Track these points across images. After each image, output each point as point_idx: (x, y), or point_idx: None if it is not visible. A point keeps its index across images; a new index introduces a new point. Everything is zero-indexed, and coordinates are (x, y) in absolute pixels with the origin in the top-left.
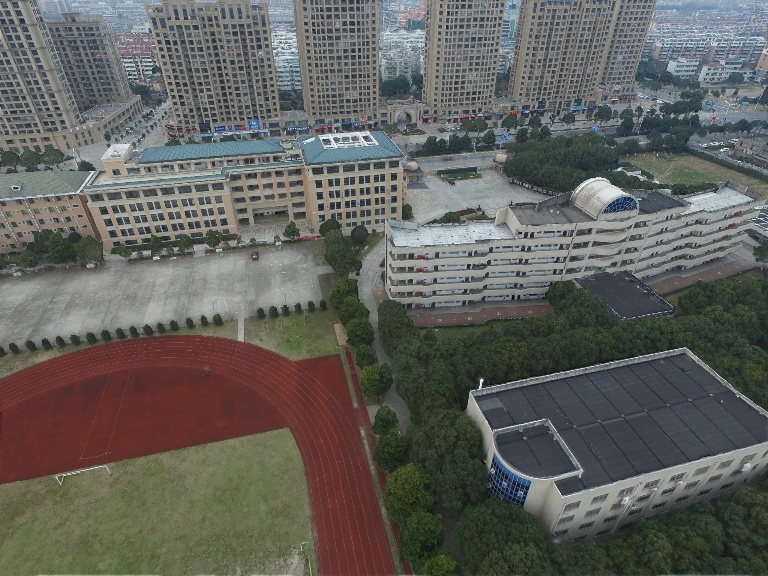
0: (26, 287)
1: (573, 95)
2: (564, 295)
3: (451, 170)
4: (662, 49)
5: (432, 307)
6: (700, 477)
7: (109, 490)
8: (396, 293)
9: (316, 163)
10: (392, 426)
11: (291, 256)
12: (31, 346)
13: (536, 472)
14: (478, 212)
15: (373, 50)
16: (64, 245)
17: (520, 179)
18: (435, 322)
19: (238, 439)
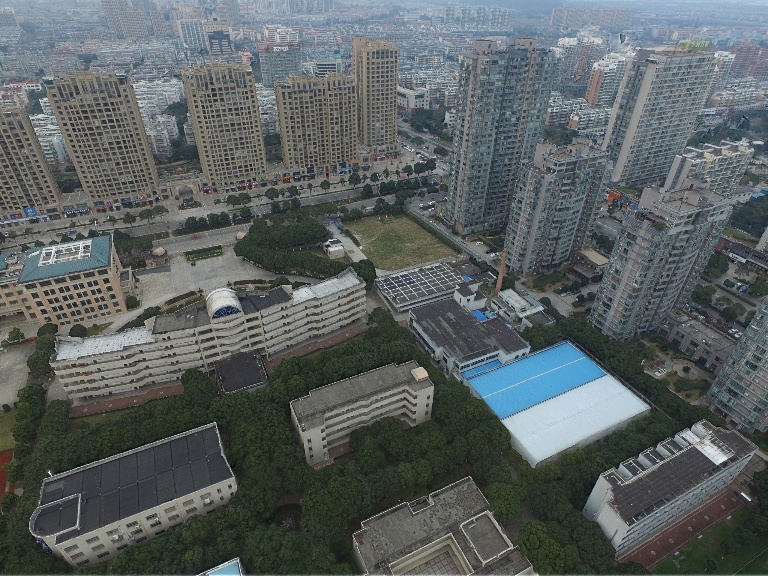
0: None
1: (338, 160)
2: (188, 380)
3: (197, 251)
4: (449, 96)
5: (110, 394)
6: (175, 513)
7: None
8: (72, 390)
9: (26, 281)
10: (12, 506)
11: (13, 358)
12: None
13: (53, 531)
14: (198, 294)
15: (139, 140)
16: None
17: (246, 257)
18: (106, 408)
19: None
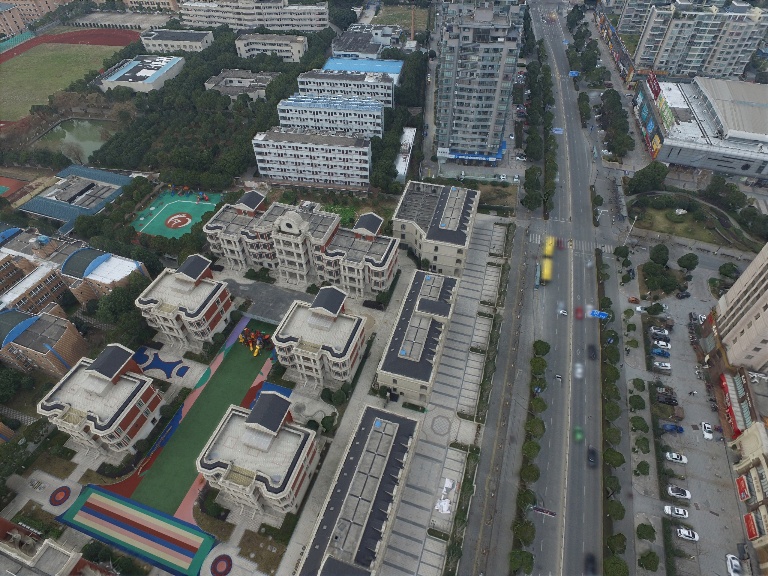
0: (100, 15)
1: None
2: None
3: (289, 0)
4: None
5: None
6: None
7: (88, 47)
8: None
9: None
10: None
11: None
12: (90, 25)
13: None
14: None
15: None
16: (113, 2)
17: None
18: None
19: (119, 46)
